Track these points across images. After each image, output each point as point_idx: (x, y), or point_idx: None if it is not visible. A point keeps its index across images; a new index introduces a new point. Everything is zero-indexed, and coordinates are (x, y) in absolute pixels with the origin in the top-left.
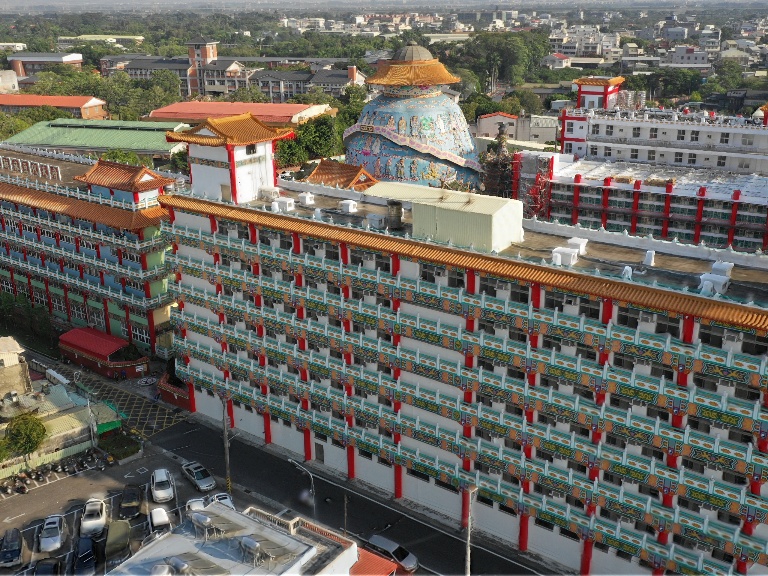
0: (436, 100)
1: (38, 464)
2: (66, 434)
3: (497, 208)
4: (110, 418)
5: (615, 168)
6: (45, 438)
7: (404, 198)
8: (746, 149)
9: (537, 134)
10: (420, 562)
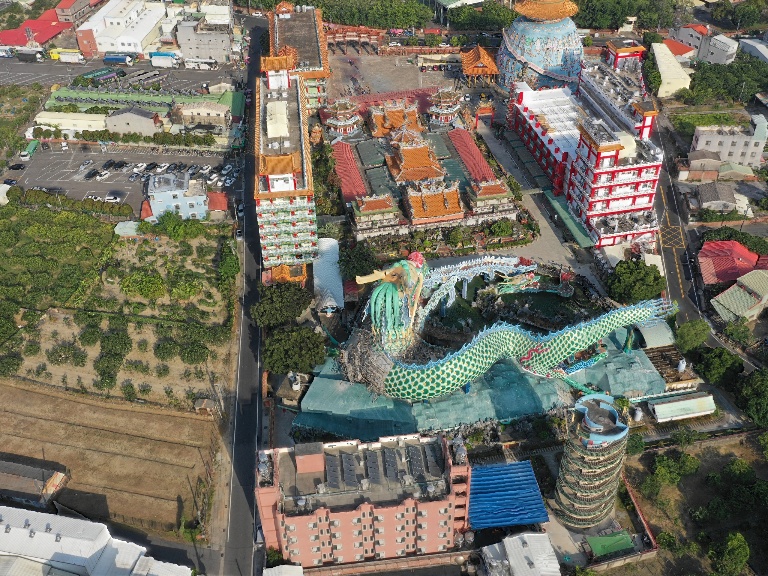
0: (546, 27)
1: (214, 150)
2: (223, 144)
3: (271, 124)
4: (238, 144)
5: (571, 109)
6: (216, 143)
7: (268, 110)
8: (621, 126)
9: (713, 52)
10: (245, 216)
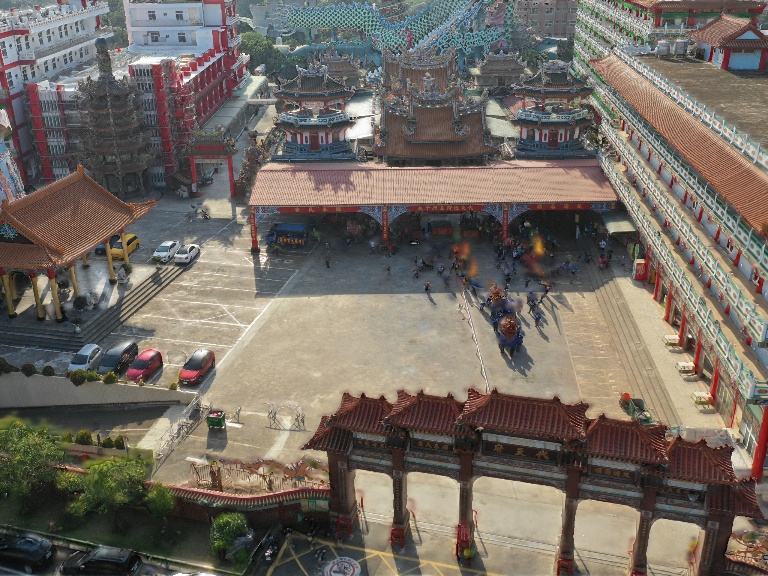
0: None
1: None
2: None
3: None
4: None
5: None
6: None
7: None
8: None
9: None
10: None
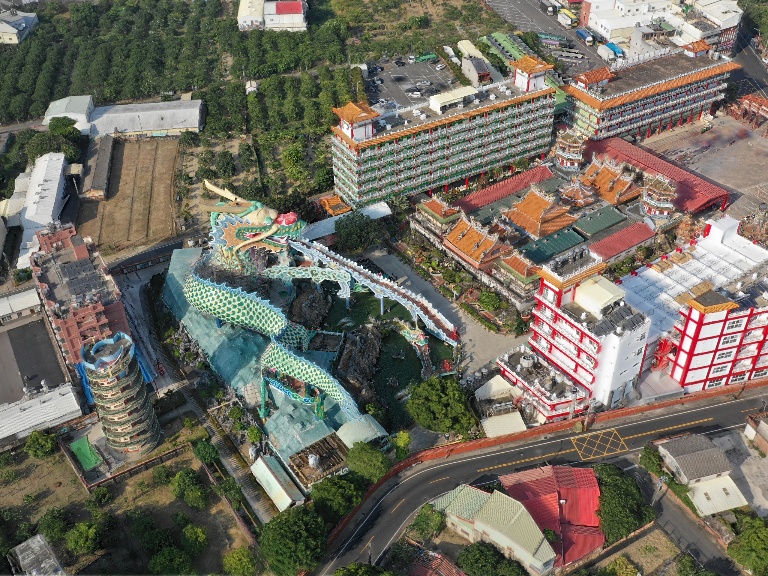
0: None
1: None
2: None
3: None
4: None
5: None
6: None
7: None
8: None
9: None
10: None
